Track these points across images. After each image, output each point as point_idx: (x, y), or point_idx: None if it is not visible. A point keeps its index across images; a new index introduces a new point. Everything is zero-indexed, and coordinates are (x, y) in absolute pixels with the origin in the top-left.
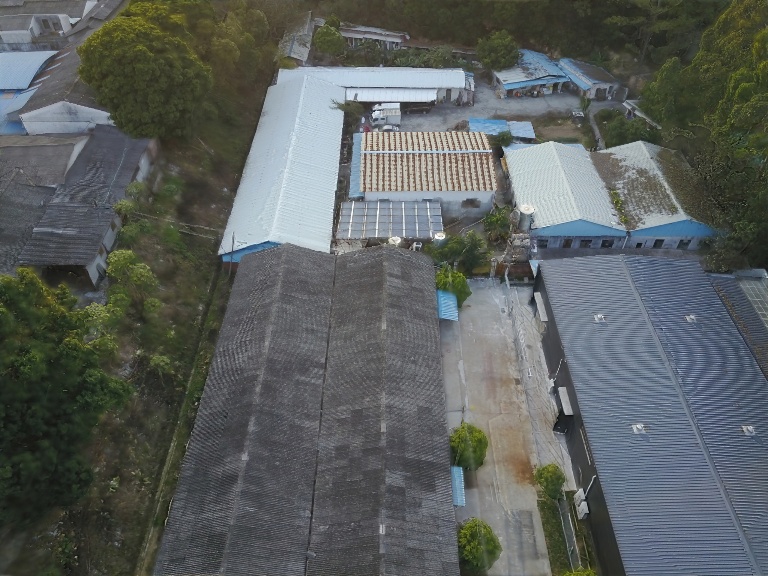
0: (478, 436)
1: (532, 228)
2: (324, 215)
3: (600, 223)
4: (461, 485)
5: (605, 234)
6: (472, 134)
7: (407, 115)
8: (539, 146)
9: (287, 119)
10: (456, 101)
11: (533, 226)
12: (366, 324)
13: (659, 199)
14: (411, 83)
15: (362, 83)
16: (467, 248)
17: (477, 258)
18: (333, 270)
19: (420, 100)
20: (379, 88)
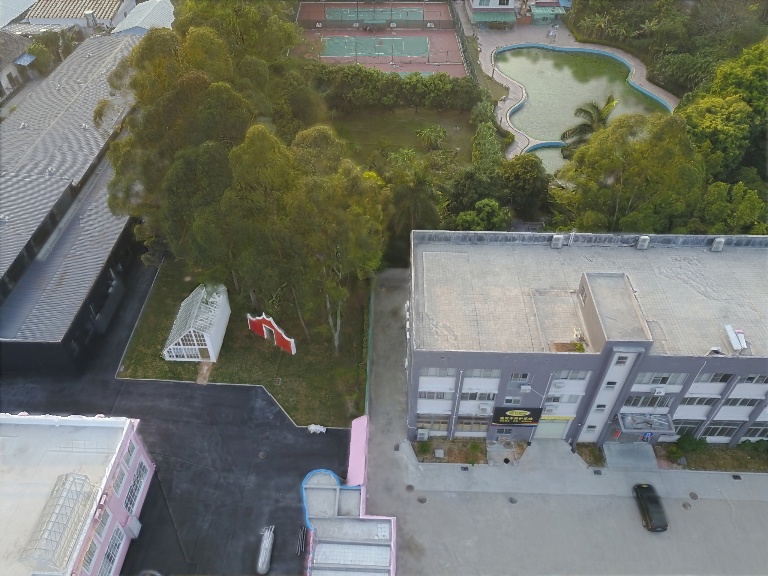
0: None
1: (112, 33)
2: None
3: None
4: None
5: None
6: None
7: None
8: None
9: None
10: None
11: (113, 32)
12: None
13: None
14: None
15: None
16: (62, 39)
17: (69, 46)
18: None
19: None
20: None
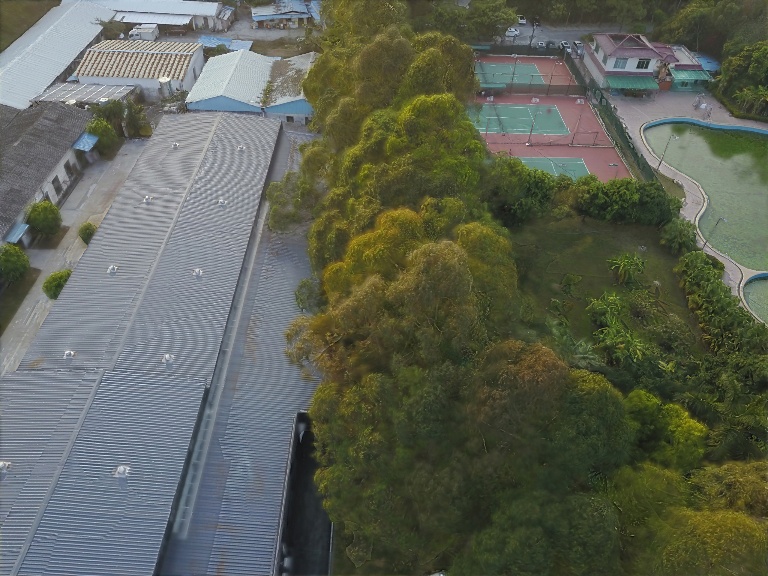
0: (44, 205)
1: (188, 102)
2: (36, 89)
3: (238, 100)
4: (21, 233)
5: (246, 110)
6: (191, 44)
7: (166, 36)
8: (233, 52)
9: (45, 27)
10: (212, 28)
11: (190, 101)
12: (6, 144)
13: (296, 87)
14: (171, 10)
15: (130, 8)
16: (127, 111)
17: (136, 119)
18: (12, 118)
19: (174, 23)
20: (144, 13)
